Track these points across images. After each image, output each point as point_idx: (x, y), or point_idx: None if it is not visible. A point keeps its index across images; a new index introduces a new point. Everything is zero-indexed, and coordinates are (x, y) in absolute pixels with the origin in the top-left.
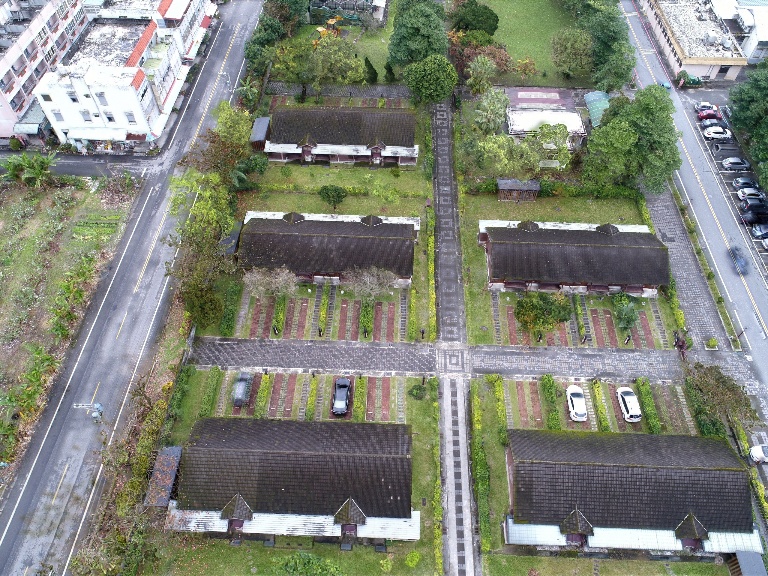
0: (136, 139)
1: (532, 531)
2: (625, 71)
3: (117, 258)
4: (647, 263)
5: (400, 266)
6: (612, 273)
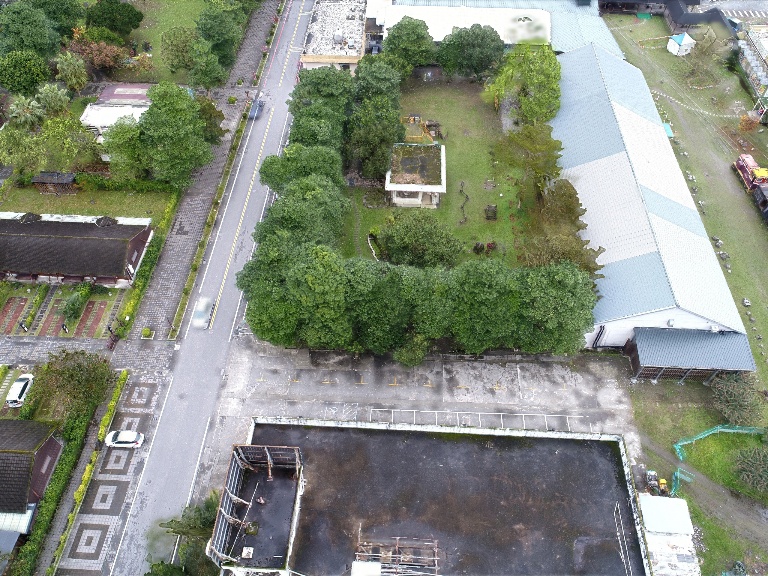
0: None
1: None
2: (209, 68)
3: None
4: (105, 254)
5: None
6: (70, 264)
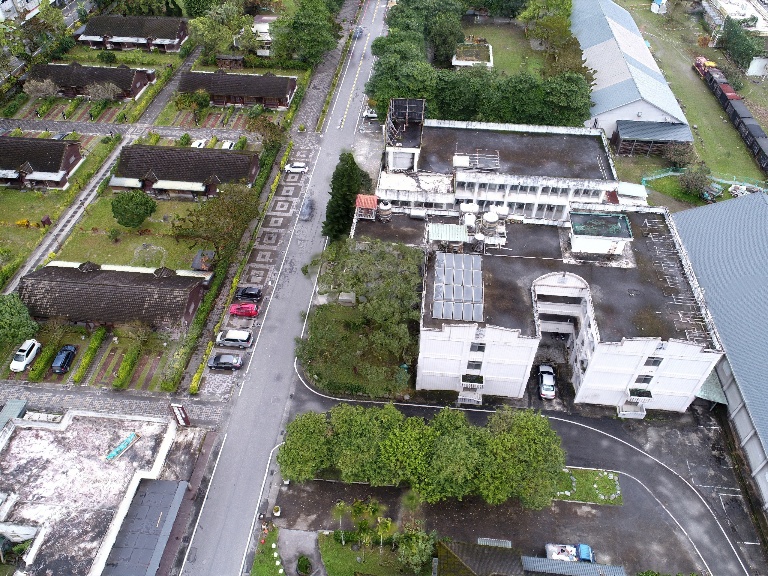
0: None
1: (124, 181)
2: (329, 2)
3: None
4: (274, 85)
5: (123, 84)
6: (251, 90)
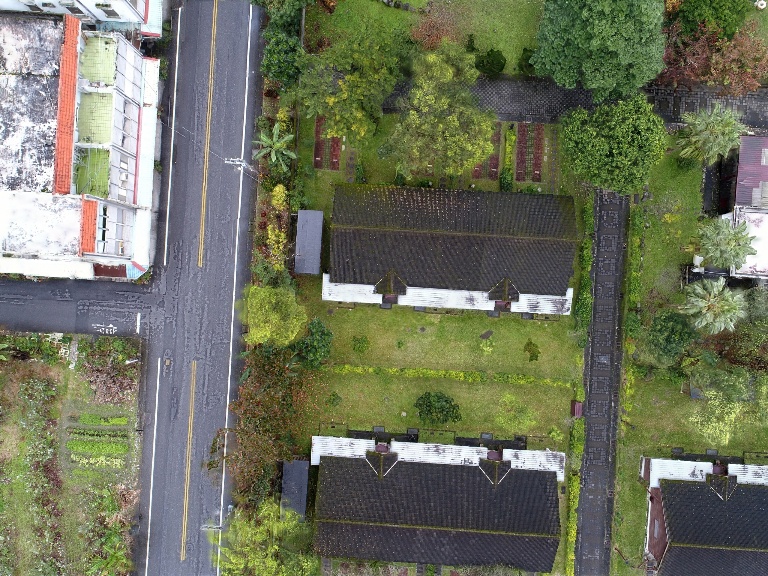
0: (111, 274)
1: None
2: None
3: (144, 501)
4: None
5: (535, 564)
6: None
